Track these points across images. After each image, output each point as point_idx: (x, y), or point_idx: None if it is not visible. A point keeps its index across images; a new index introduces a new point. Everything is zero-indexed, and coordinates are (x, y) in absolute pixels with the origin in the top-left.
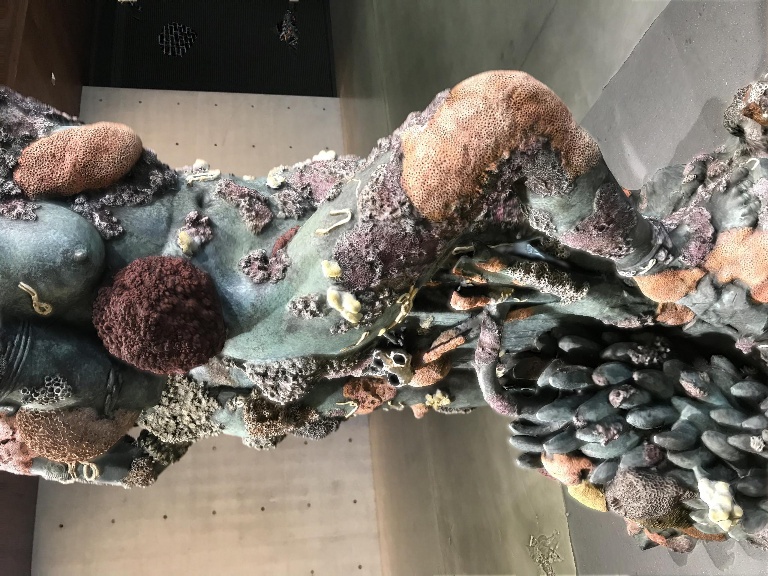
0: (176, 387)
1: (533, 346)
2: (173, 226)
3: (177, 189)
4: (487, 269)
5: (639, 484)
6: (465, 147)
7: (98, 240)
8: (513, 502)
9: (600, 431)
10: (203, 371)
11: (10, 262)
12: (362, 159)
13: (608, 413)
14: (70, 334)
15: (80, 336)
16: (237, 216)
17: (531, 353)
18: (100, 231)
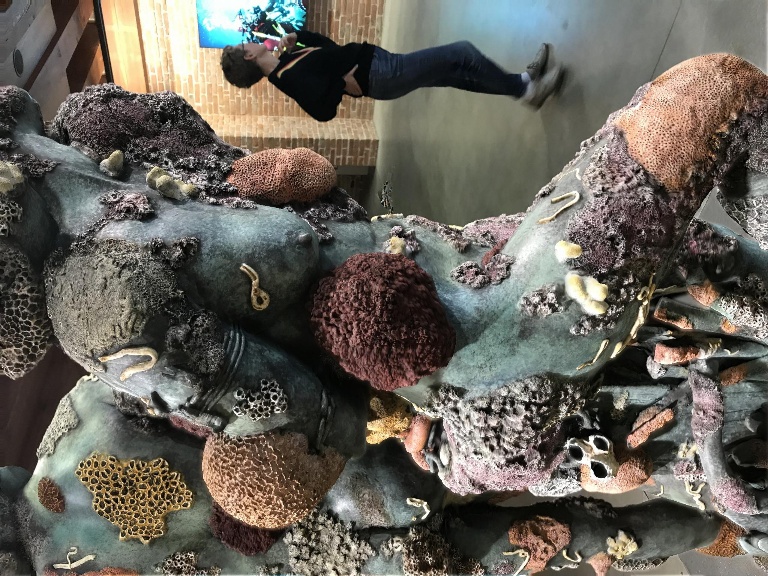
0: (318, 532)
1: (743, 431)
2: (378, 240)
3: None
4: (700, 298)
5: None
6: (691, 109)
7: None
8: None
9: None
10: (351, 506)
11: (233, 242)
12: None
13: None
14: (278, 346)
15: (288, 351)
16: (437, 237)
17: (745, 438)
18: None
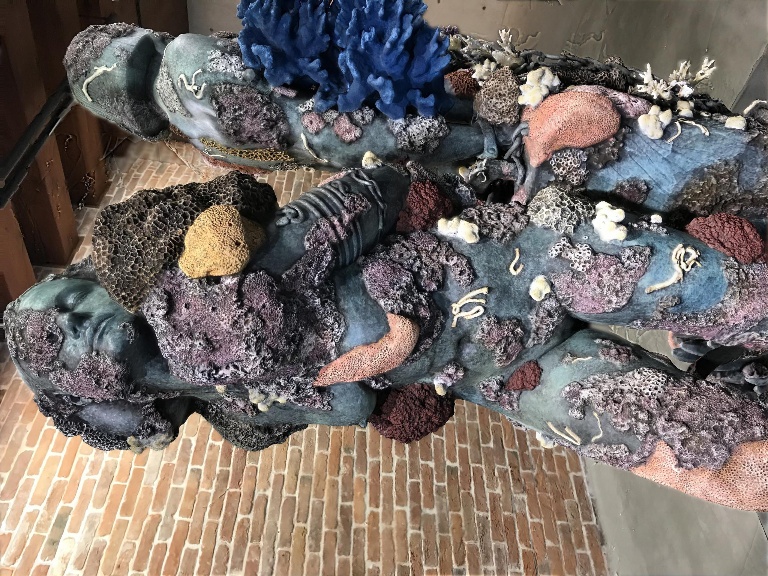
0: None
1: None
2: (432, 370)
3: None
4: None
5: None
6: None
7: (374, 404)
8: (697, 9)
9: None
10: None
11: None
12: (646, 272)
13: None
14: None
15: None
16: (489, 358)
17: None
18: None
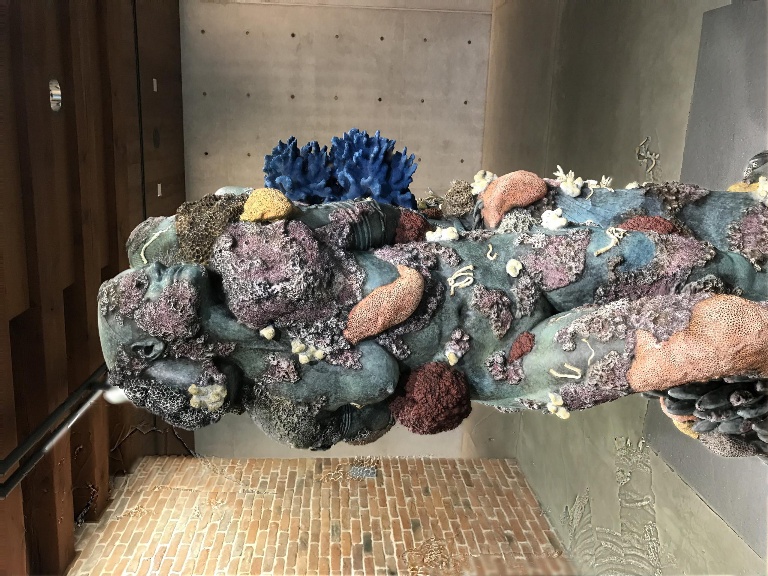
0: None
1: None
2: (442, 340)
3: (444, 301)
4: None
5: (727, 444)
6: (686, 373)
7: (398, 371)
8: None
9: (713, 418)
10: None
11: (347, 395)
12: (590, 242)
13: (725, 404)
14: None
15: None
16: (487, 326)
17: None
18: (396, 357)
